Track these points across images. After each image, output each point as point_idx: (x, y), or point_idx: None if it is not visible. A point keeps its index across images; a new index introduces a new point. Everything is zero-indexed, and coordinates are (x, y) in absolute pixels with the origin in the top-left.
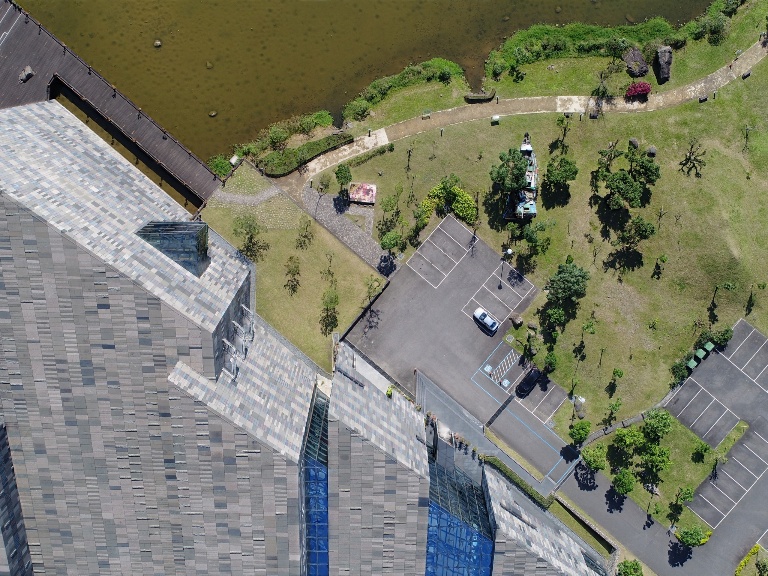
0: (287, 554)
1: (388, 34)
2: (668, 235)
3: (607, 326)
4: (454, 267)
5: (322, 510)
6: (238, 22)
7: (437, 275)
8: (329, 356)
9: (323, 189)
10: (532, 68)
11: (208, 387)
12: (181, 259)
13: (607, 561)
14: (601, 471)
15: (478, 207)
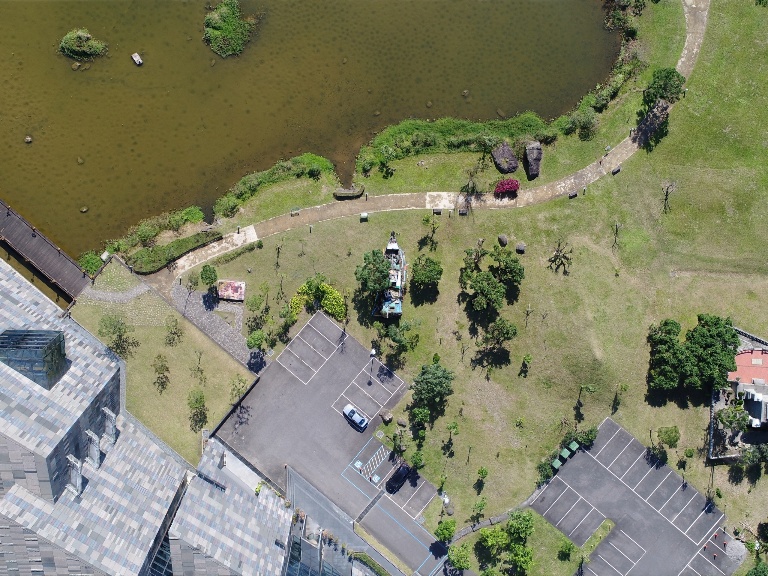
0: None
1: (259, 129)
2: (535, 334)
3: (475, 424)
4: (324, 363)
5: None
6: (109, 118)
7: (307, 371)
8: (199, 453)
9: (192, 286)
10: (402, 164)
11: (43, 511)
12: (35, 369)
13: None
14: None
15: (347, 304)
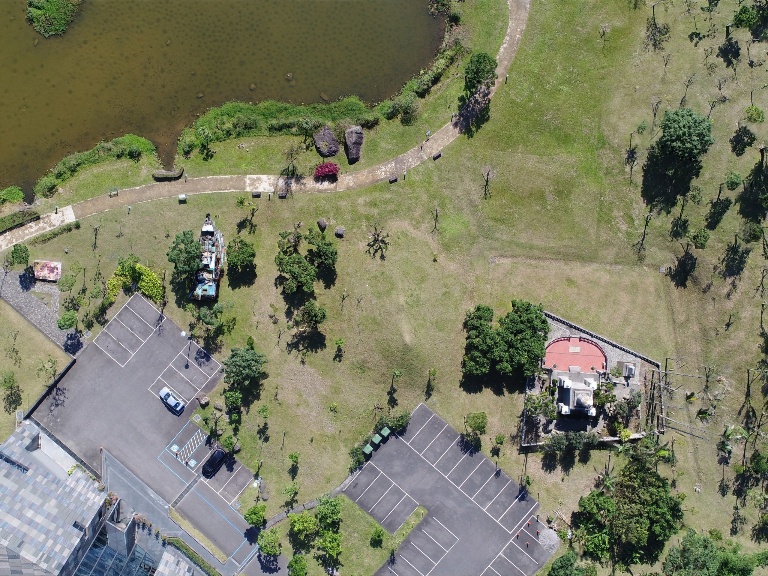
0: None
1: (81, 110)
2: (350, 318)
3: (289, 408)
4: (141, 346)
5: None
6: None
7: (124, 354)
8: None
9: (8, 266)
10: (222, 146)
11: None
12: None
13: None
14: (284, 554)
15: (165, 286)
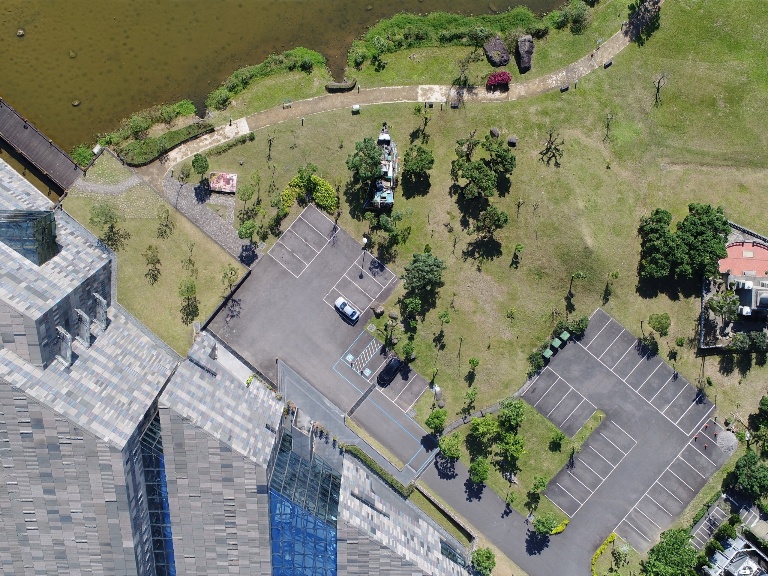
0: (120, 541)
1: (251, 23)
2: (526, 224)
3: (466, 315)
4: (315, 256)
5: (163, 497)
6: (101, 11)
7: (298, 264)
8: (190, 345)
9: (184, 178)
10: (394, 57)
11: (32, 374)
12: (25, 247)
13: (467, 549)
14: (461, 460)
15: (339, 196)
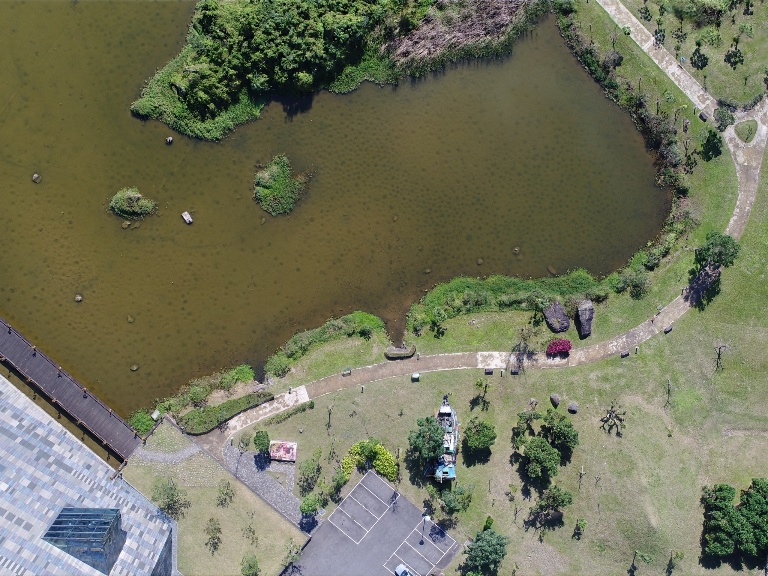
0: None
1: (309, 287)
2: (588, 496)
3: None
4: (376, 523)
5: None
6: (159, 276)
7: (359, 531)
8: None
9: (244, 447)
10: (453, 323)
11: None
12: (92, 549)
13: None
14: None
15: (399, 463)
